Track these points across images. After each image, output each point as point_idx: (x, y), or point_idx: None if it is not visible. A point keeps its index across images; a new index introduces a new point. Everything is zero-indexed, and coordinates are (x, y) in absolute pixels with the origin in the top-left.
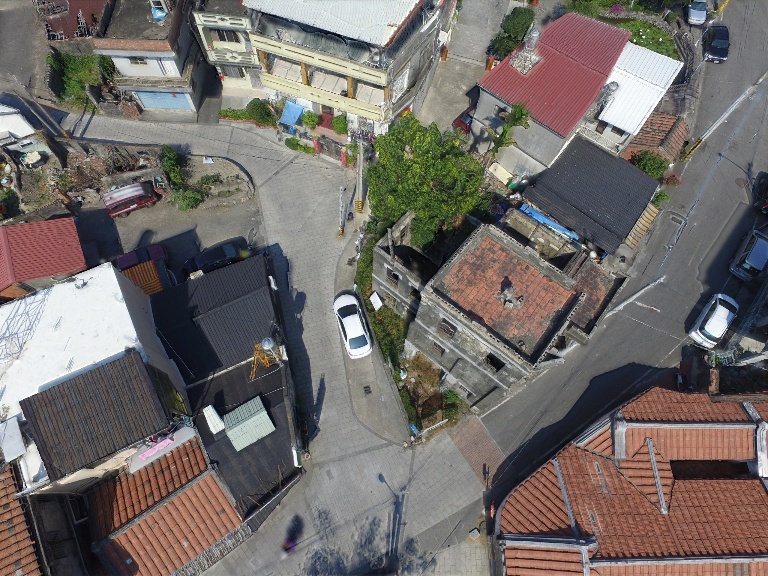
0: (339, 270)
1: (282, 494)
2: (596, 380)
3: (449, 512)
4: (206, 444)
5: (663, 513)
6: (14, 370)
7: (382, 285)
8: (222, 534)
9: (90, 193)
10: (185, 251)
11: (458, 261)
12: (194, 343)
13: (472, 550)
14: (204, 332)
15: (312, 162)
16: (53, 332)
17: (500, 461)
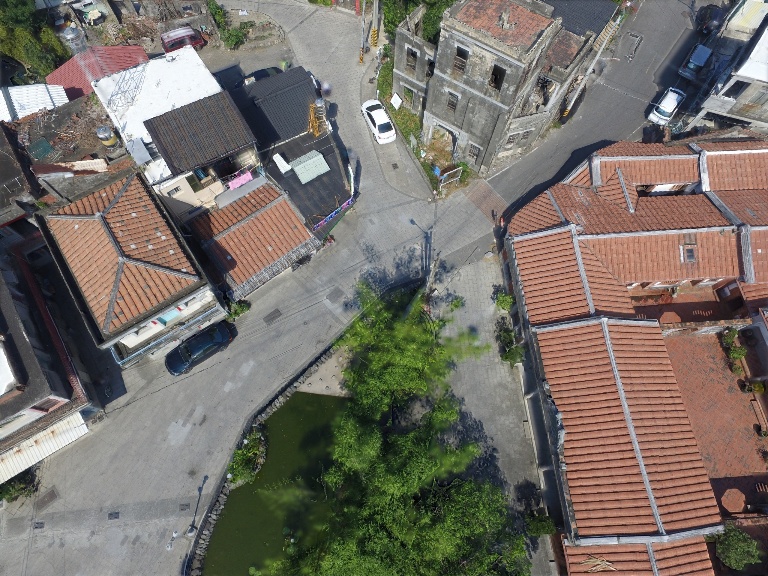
0: (363, 87)
1: (340, 215)
2: (576, 152)
3: (468, 241)
4: (278, 180)
5: (631, 212)
6: (131, 113)
7: (402, 79)
8: (296, 244)
9: (146, 42)
10: (233, 80)
11: (466, 5)
12: (257, 121)
13: (488, 265)
14: (264, 112)
15: (330, 13)
16: (156, 89)
17: (505, 207)
